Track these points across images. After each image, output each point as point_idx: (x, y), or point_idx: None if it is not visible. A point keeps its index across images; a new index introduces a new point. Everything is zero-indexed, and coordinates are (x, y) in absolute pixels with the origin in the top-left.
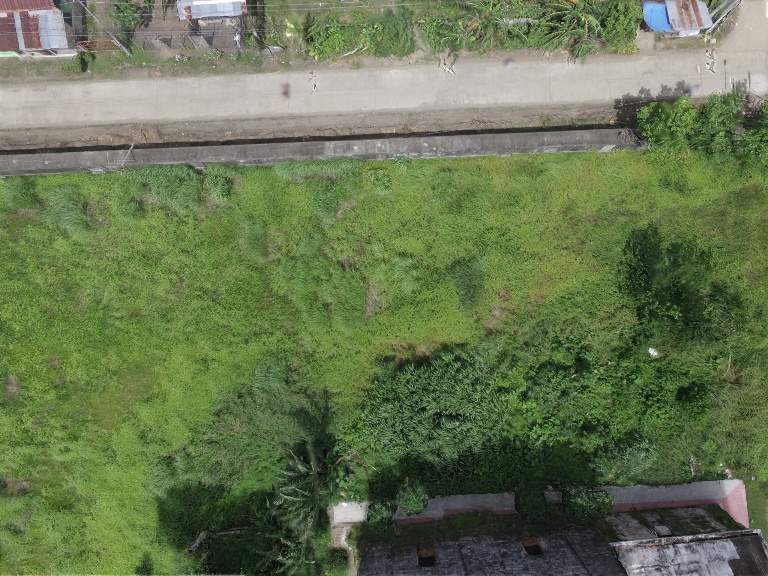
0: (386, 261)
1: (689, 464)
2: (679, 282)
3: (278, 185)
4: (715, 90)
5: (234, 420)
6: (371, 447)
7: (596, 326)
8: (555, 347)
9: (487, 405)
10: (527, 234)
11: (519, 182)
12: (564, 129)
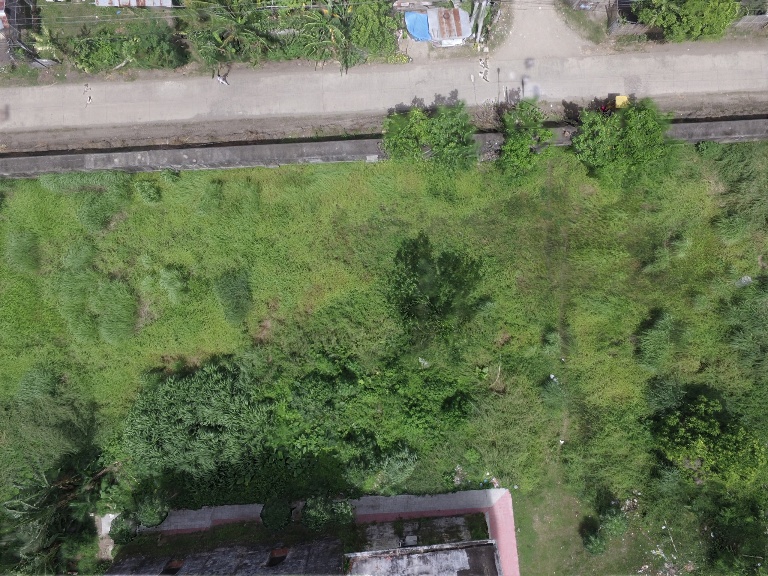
0: (156, 273)
1: (451, 473)
2: (450, 291)
3: (49, 198)
4: (488, 99)
5: (1, 432)
6: (132, 459)
7: (363, 336)
8: (318, 357)
9: (246, 416)
10: (296, 244)
11: (288, 193)
12: (333, 139)
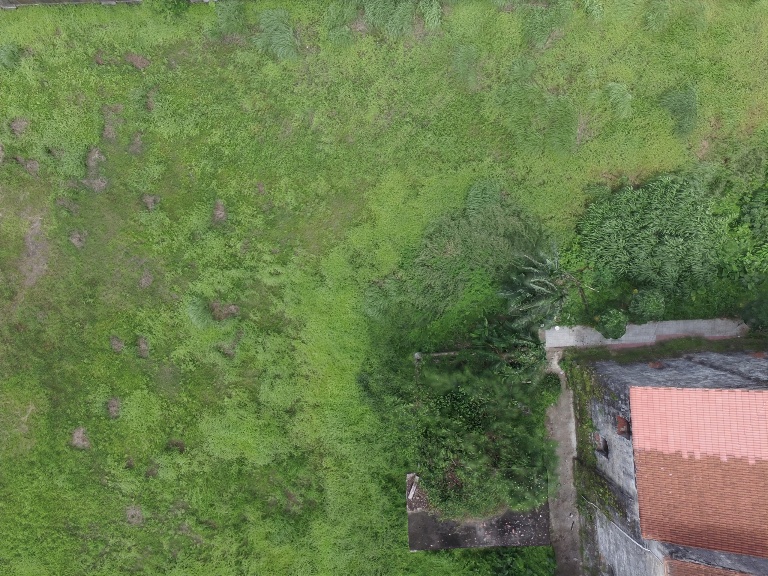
0: None
1: None
2: None
3: (489, 12)
4: None
5: (448, 243)
6: (589, 267)
7: None
8: None
9: (707, 226)
10: (738, 64)
11: (731, 12)
12: None
